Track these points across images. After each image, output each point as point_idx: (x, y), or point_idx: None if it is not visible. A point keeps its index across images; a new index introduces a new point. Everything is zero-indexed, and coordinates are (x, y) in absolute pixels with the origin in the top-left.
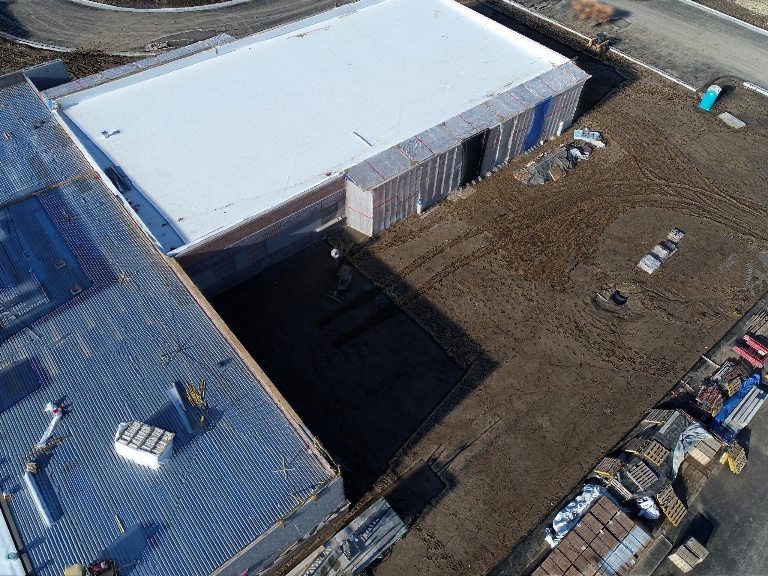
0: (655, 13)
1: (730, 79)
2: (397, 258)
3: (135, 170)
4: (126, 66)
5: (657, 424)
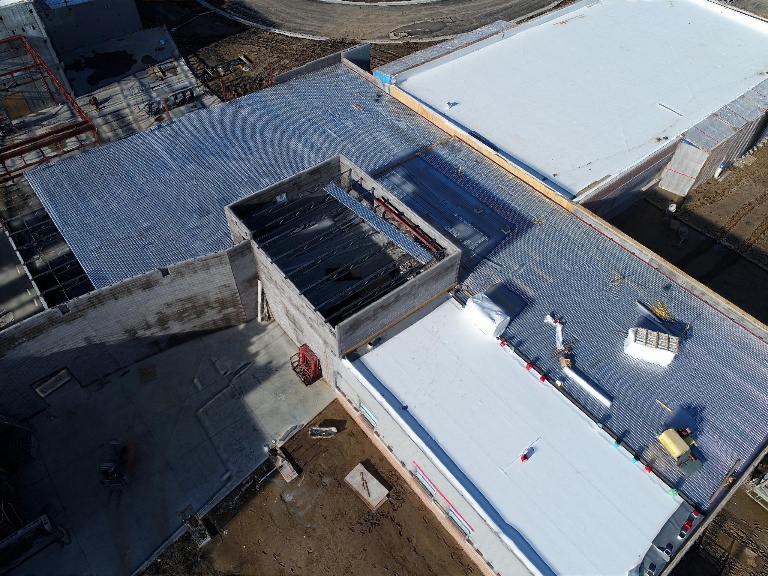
0: None
1: None
2: (716, 214)
3: (491, 135)
4: (434, 48)
5: None
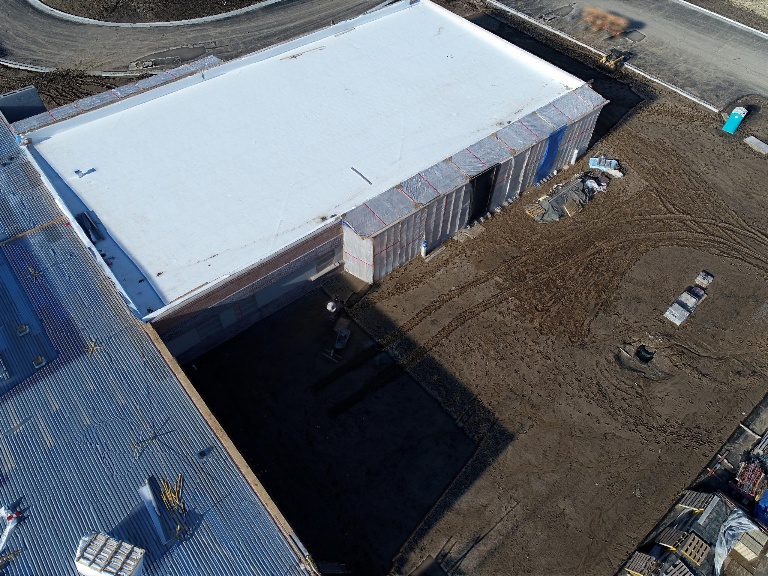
0: (671, 24)
1: (754, 98)
2: (400, 309)
3: (111, 215)
4: (104, 94)
5: (694, 510)
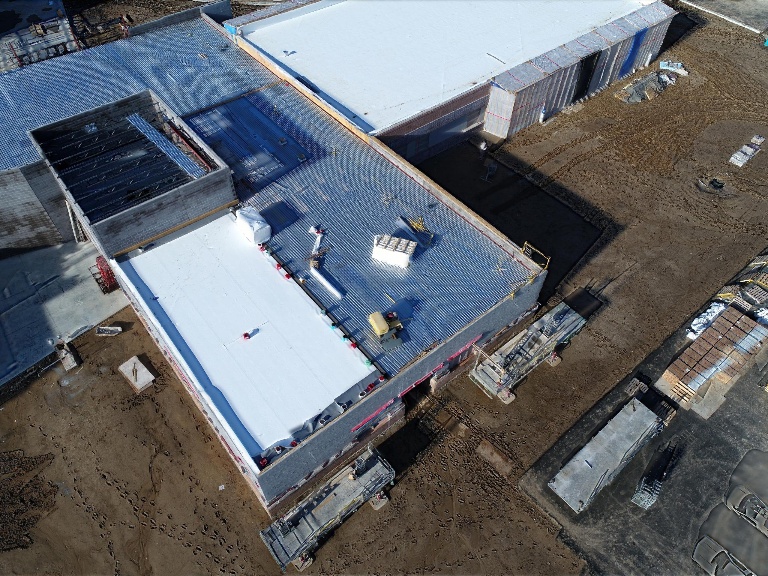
0: None
1: None
2: (530, 154)
3: (318, 79)
4: (287, 3)
5: (763, 264)
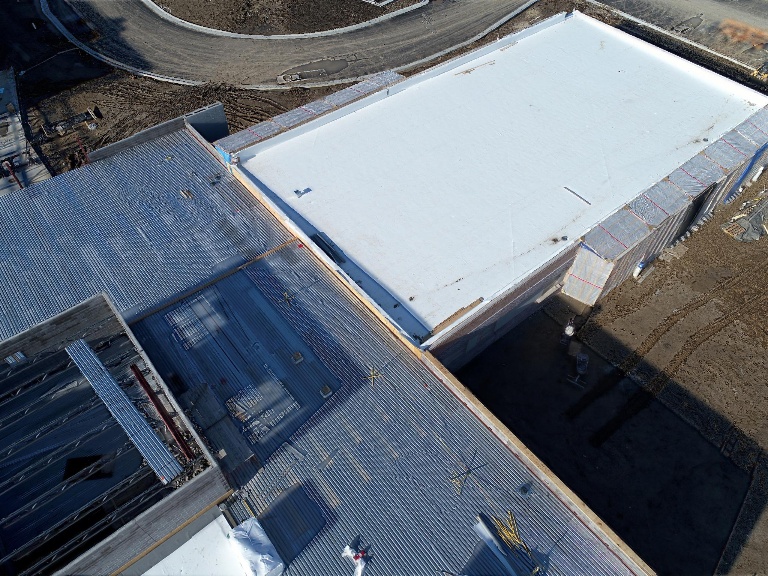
0: None
1: None
2: (628, 332)
3: (342, 237)
4: (297, 111)
5: None
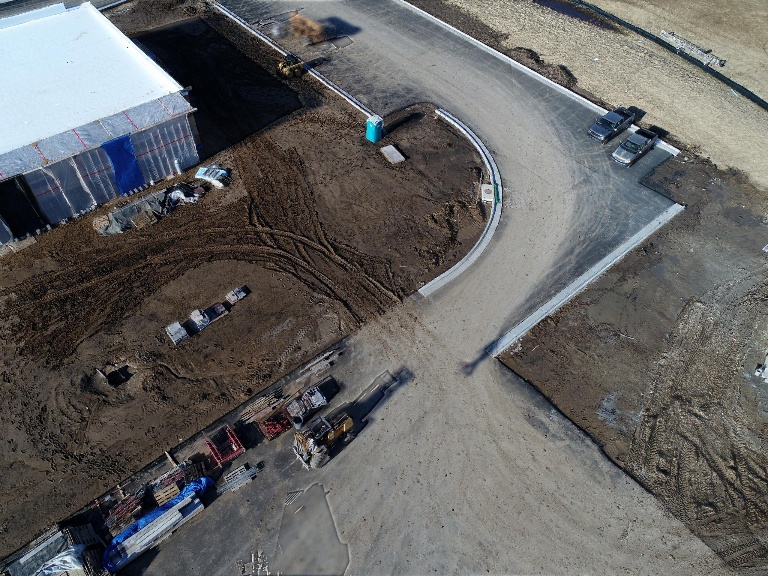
0: (387, 30)
1: (424, 106)
2: None
3: None
4: None
5: None
